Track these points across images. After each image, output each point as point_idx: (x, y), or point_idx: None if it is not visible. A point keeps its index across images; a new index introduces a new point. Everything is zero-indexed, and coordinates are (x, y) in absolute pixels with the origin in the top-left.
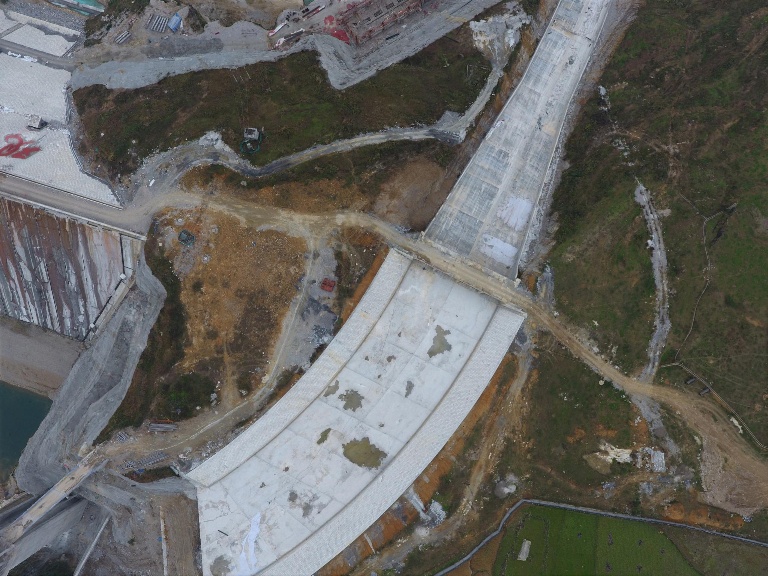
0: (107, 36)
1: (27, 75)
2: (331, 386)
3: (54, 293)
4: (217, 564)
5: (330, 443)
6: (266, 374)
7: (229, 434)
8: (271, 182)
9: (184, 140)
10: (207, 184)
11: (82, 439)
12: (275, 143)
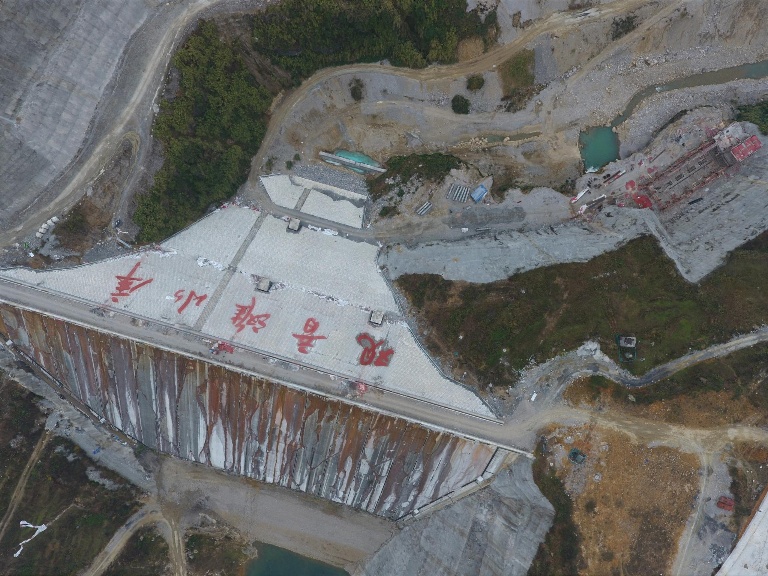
0: (403, 205)
1: (338, 254)
2: None
3: (386, 484)
4: None
5: None
6: None
7: None
8: (660, 396)
9: (561, 350)
10: (595, 400)
11: None
12: (648, 348)
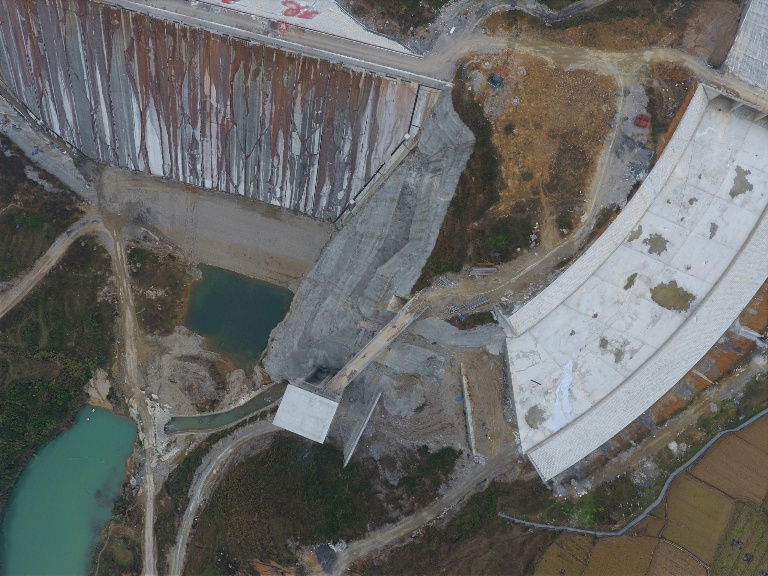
0: None
1: None
2: (634, 231)
3: (320, 167)
4: (532, 414)
5: (637, 288)
6: (584, 213)
7: (549, 275)
8: (576, 22)
9: None
10: (512, 27)
11: (388, 294)
12: None
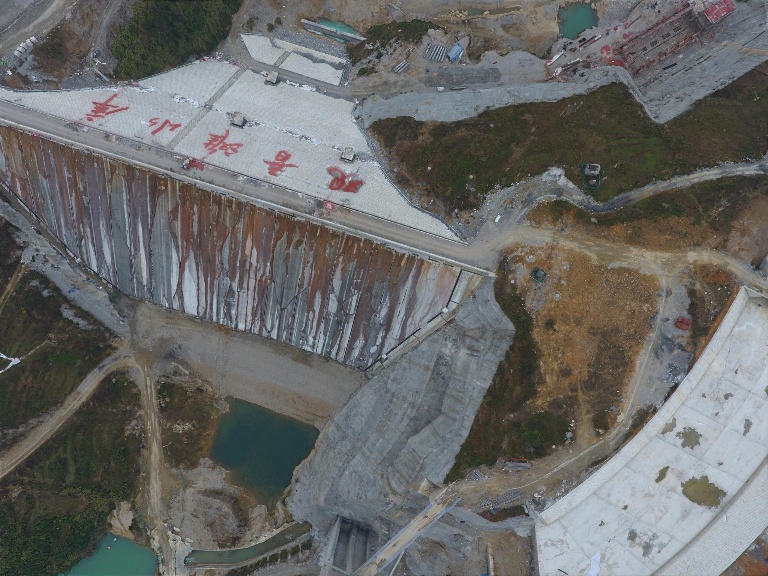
0: (381, 65)
1: (314, 105)
2: (668, 423)
3: (355, 324)
4: None
5: (669, 481)
6: (621, 413)
7: (583, 473)
8: (621, 219)
9: (526, 176)
10: (557, 221)
11: (420, 475)
12: (612, 179)
